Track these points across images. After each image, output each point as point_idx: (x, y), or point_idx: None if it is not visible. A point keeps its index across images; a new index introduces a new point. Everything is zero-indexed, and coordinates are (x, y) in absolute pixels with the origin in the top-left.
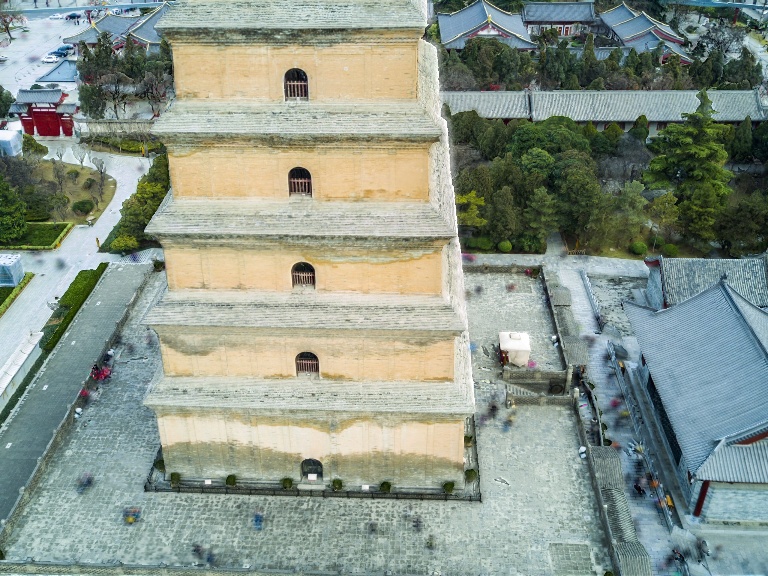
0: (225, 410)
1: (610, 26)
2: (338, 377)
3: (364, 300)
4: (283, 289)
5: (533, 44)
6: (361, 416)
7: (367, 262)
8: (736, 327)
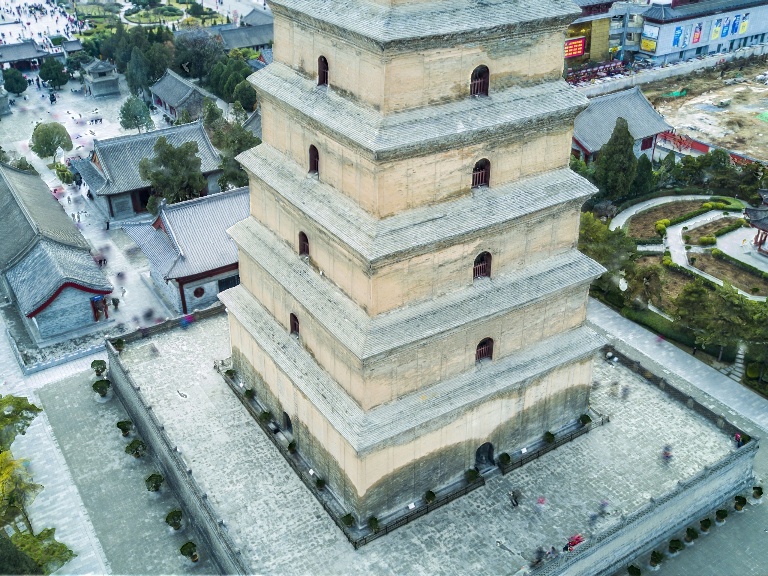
0: None
1: None
2: None
3: None
4: None
5: None
6: None
7: None
8: (218, 204)
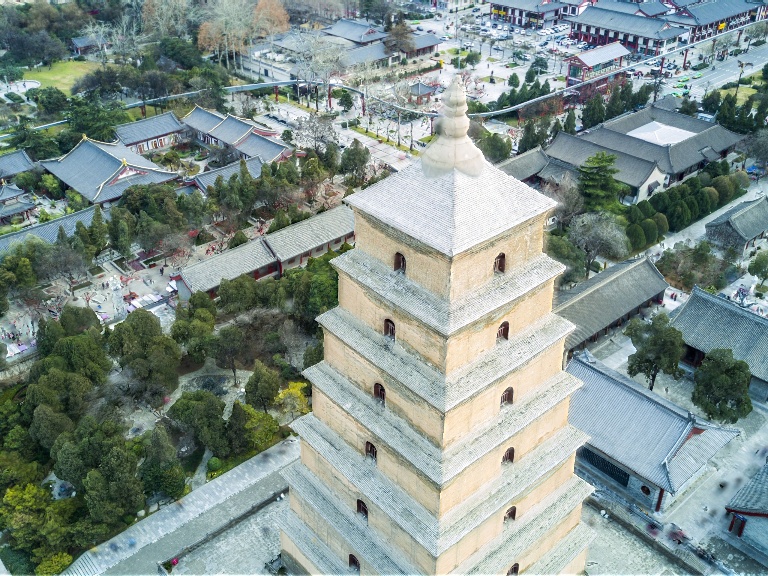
0: None
1: (204, 131)
2: (527, 568)
3: (541, 508)
4: (498, 533)
5: (174, 174)
6: None
7: (542, 483)
8: (611, 385)
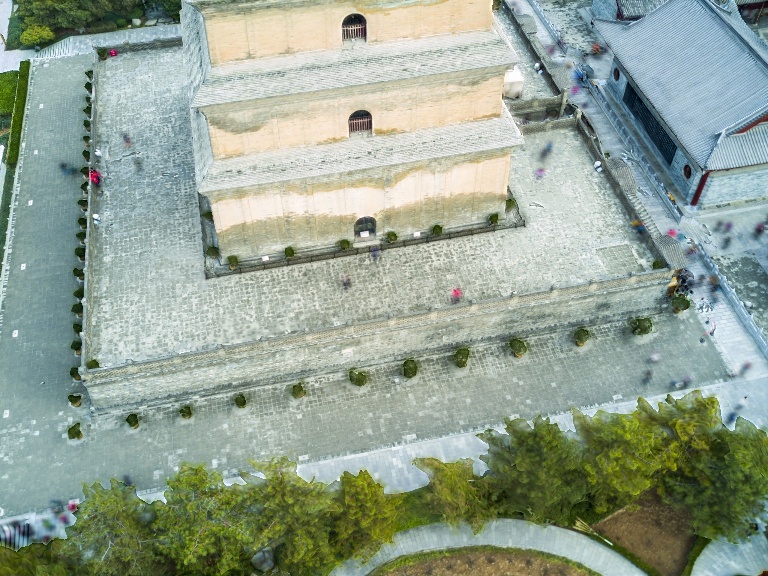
0: (282, 184)
1: None
2: (391, 131)
3: (417, 46)
4: (333, 47)
5: None
6: (416, 166)
7: (420, 4)
8: (713, 27)
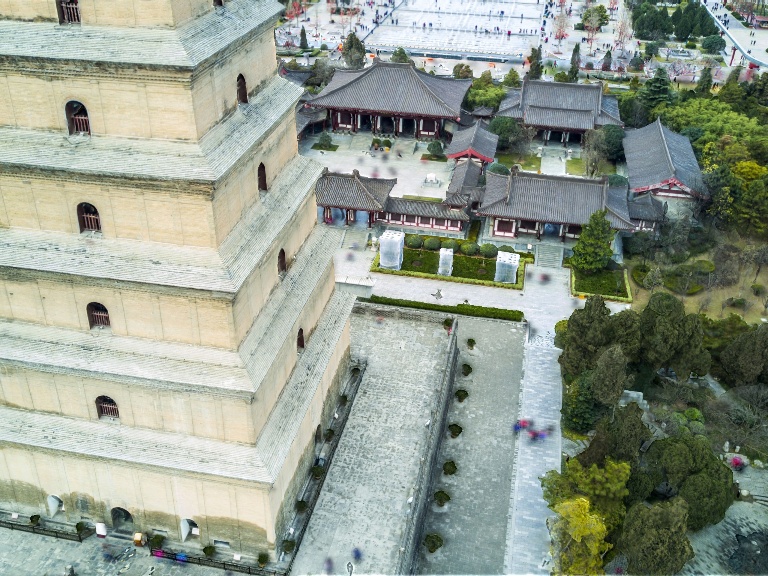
0: None
1: None
2: None
3: None
4: None
5: None
6: None
7: None
8: None
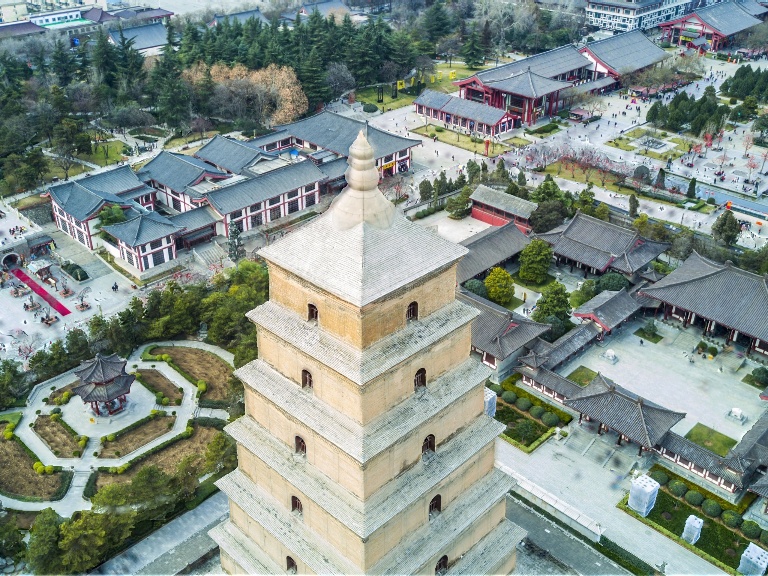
0: None
1: None
2: None
3: None
4: None
5: None
6: None
7: None
8: None
